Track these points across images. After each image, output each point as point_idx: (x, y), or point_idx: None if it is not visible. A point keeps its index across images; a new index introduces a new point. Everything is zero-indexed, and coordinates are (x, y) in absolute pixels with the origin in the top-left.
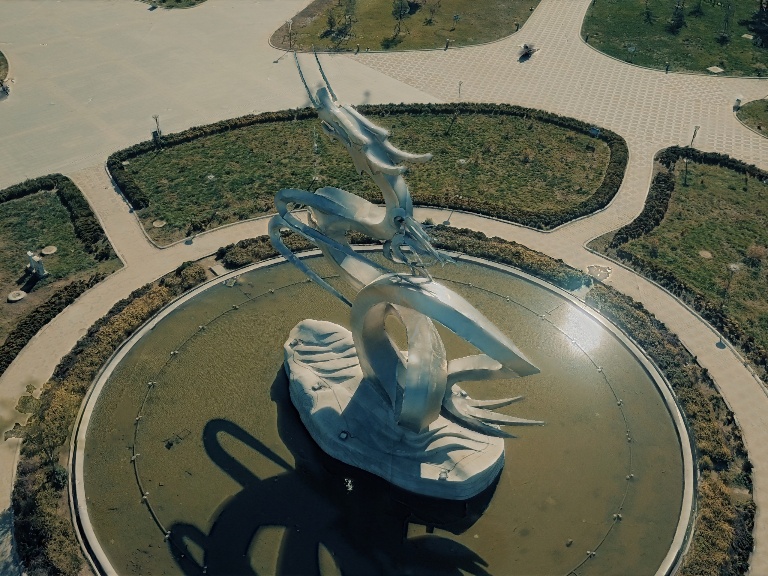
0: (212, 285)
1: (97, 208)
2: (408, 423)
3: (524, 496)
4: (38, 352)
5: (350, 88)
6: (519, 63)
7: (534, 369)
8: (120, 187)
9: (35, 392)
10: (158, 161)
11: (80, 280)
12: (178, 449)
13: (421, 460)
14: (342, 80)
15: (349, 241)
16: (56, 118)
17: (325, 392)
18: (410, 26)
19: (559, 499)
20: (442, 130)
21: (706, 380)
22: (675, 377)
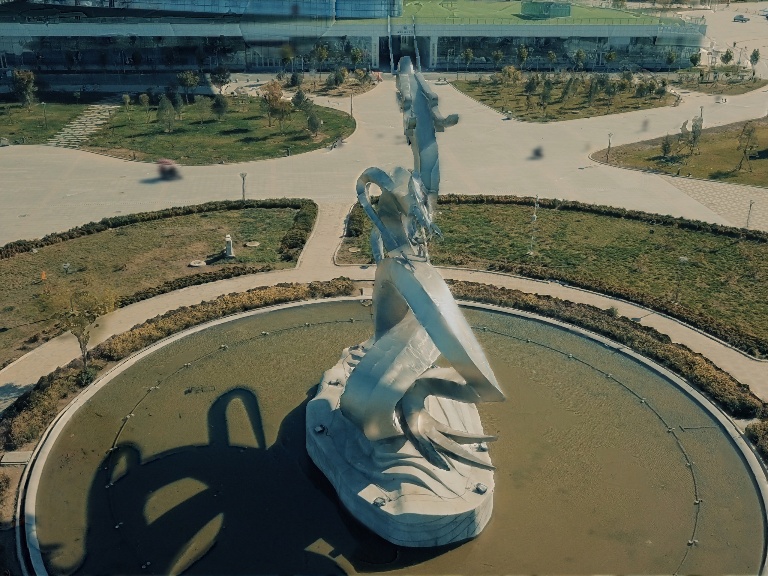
0: (349, 299)
1: (318, 228)
2: (350, 414)
3: (470, 574)
4: (170, 300)
5: (638, 198)
6: None
7: (490, 386)
8: (349, 219)
9: (138, 322)
10: None
11: (251, 266)
12: (192, 397)
13: (374, 481)
14: (636, 192)
15: (511, 304)
16: (351, 169)
17: (335, 387)
18: (757, 166)
19: None
20: (710, 248)
21: None
22: None
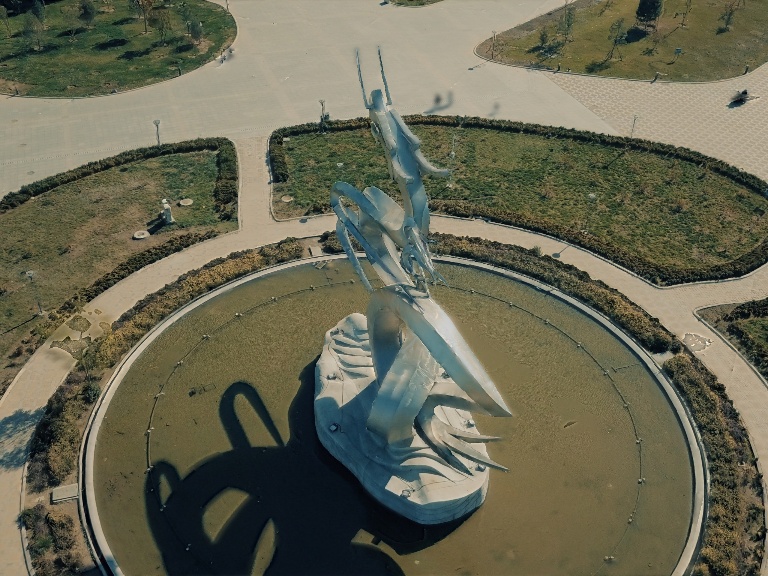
0: (302, 263)
1: (243, 174)
2: (376, 430)
3: (486, 540)
4: (133, 286)
5: (530, 105)
6: (727, 108)
7: (503, 411)
8: (271, 159)
9: (113, 318)
10: (315, 143)
11: (196, 233)
12: (198, 398)
13: (394, 472)
14: (526, 96)
15: (448, 251)
16: (250, 89)
17: (336, 383)
18: (626, 53)
19: (520, 555)
20: (602, 162)
21: (756, 486)
22: (718, 472)
